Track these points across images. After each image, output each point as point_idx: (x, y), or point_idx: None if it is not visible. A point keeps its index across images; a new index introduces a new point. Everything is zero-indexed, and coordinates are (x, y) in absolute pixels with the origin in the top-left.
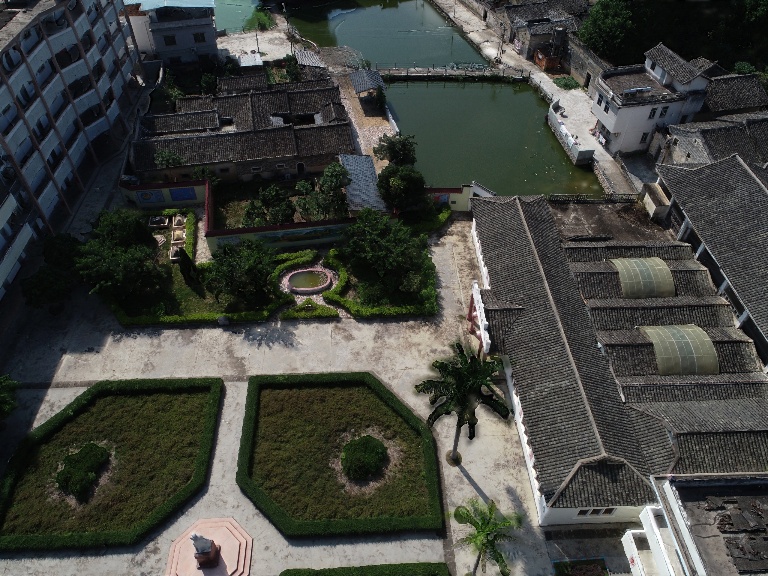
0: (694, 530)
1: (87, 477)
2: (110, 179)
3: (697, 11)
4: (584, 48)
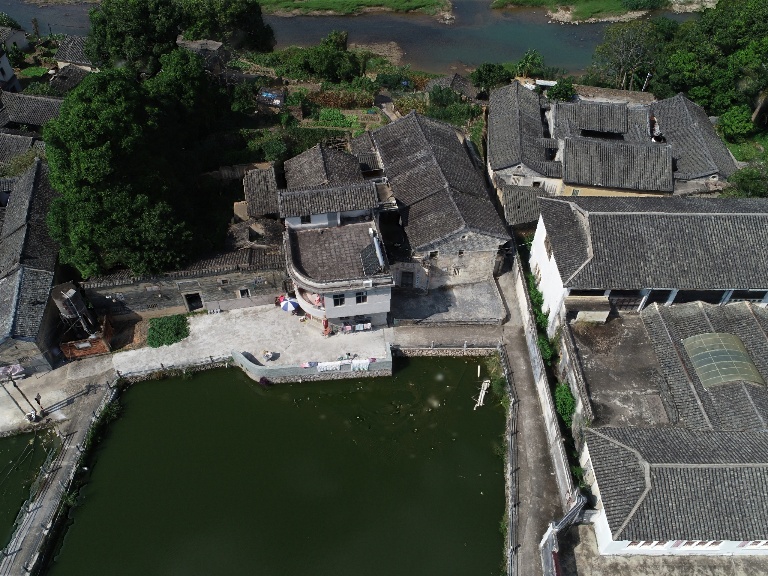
0: None
1: None
2: None
3: None
4: (152, 279)
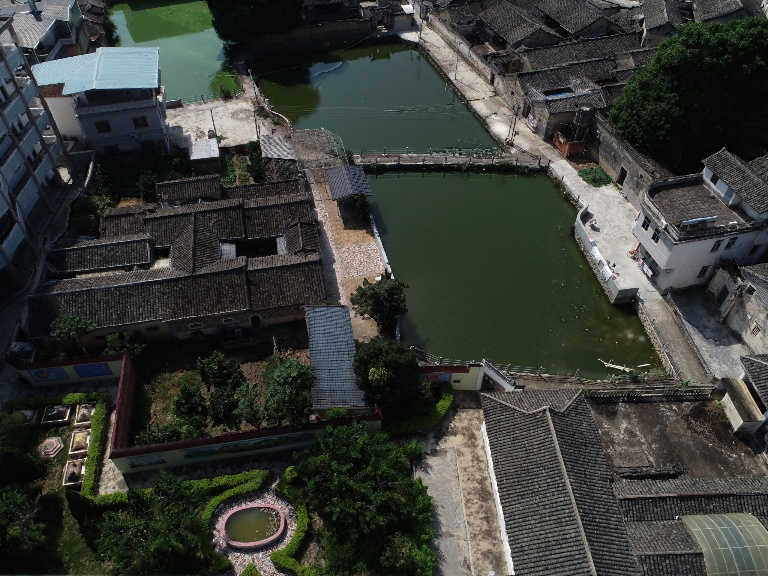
0: None
1: None
2: (4, 336)
3: (761, 94)
4: (618, 137)
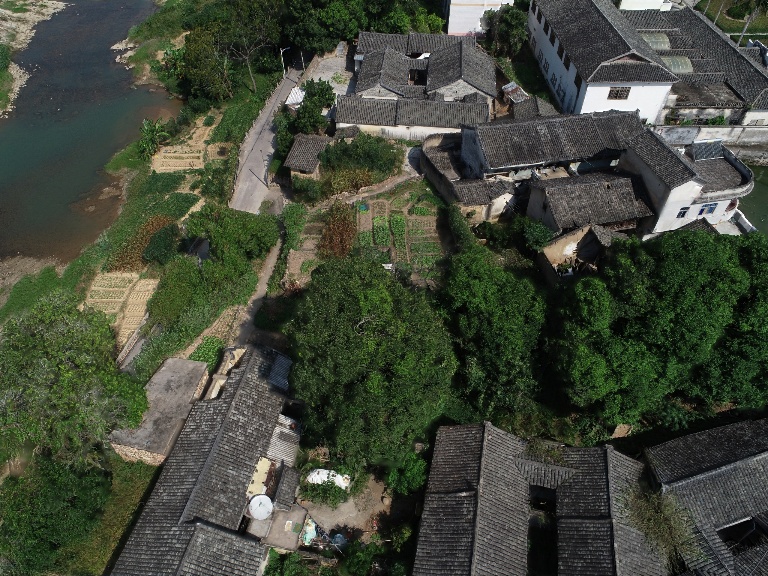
0: None
1: None
2: None
3: None
4: None
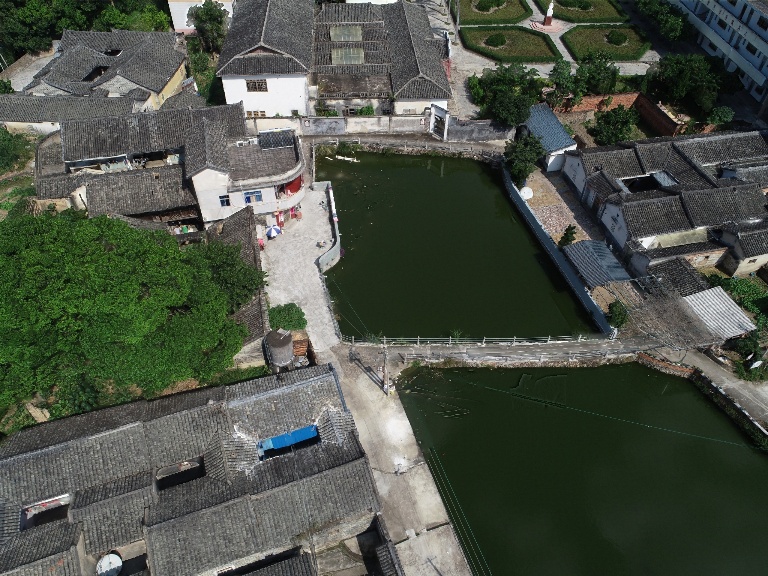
0: None
1: (611, 33)
2: None
3: None
4: None
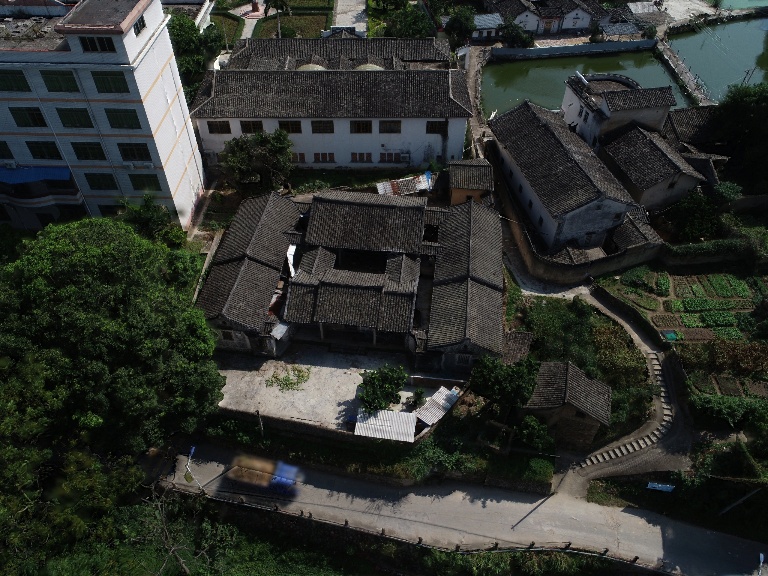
0: (192, 5)
1: None
2: None
3: None
4: None
